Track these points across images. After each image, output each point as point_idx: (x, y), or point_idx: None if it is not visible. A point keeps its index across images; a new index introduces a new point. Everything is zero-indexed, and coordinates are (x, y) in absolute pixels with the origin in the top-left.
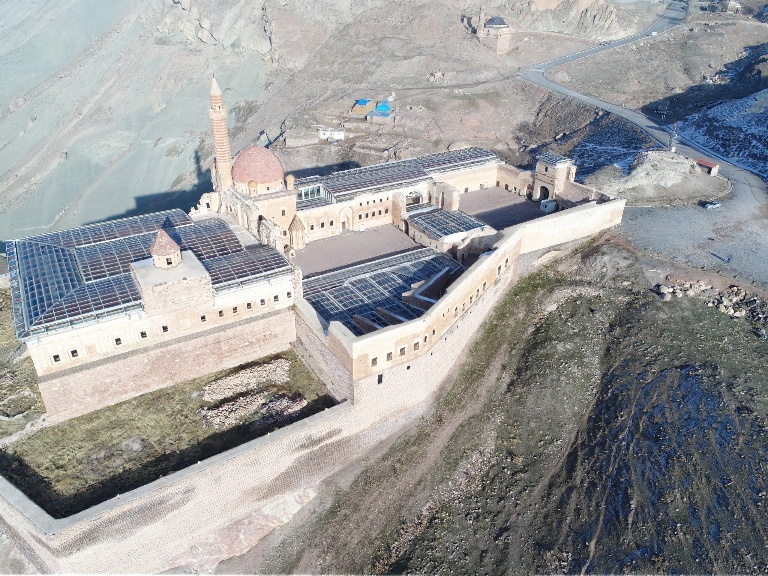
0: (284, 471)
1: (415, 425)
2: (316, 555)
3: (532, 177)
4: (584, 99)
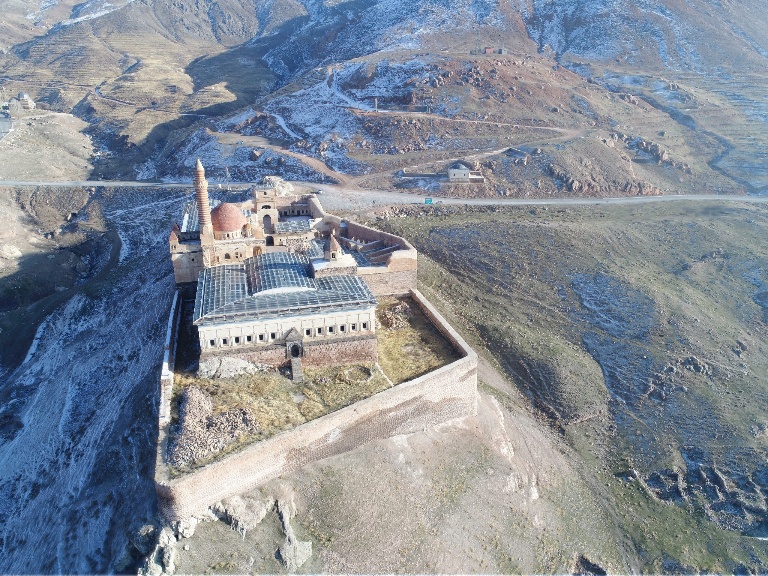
0: None
1: None
2: None
3: (253, 203)
4: (59, 184)
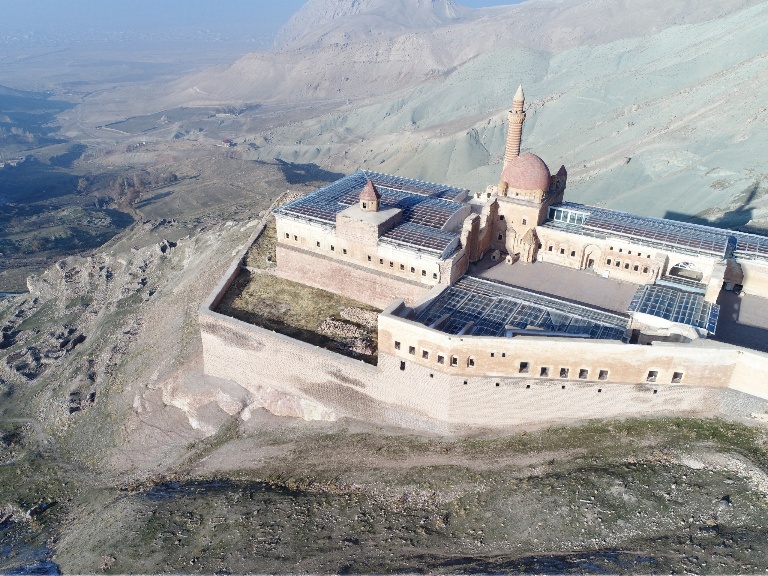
0: (320, 383)
1: (430, 437)
2: (291, 448)
3: None
4: None
